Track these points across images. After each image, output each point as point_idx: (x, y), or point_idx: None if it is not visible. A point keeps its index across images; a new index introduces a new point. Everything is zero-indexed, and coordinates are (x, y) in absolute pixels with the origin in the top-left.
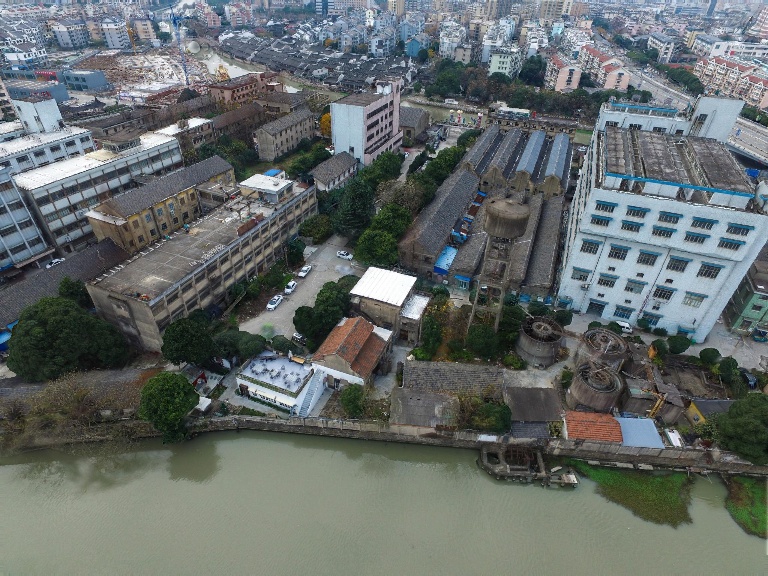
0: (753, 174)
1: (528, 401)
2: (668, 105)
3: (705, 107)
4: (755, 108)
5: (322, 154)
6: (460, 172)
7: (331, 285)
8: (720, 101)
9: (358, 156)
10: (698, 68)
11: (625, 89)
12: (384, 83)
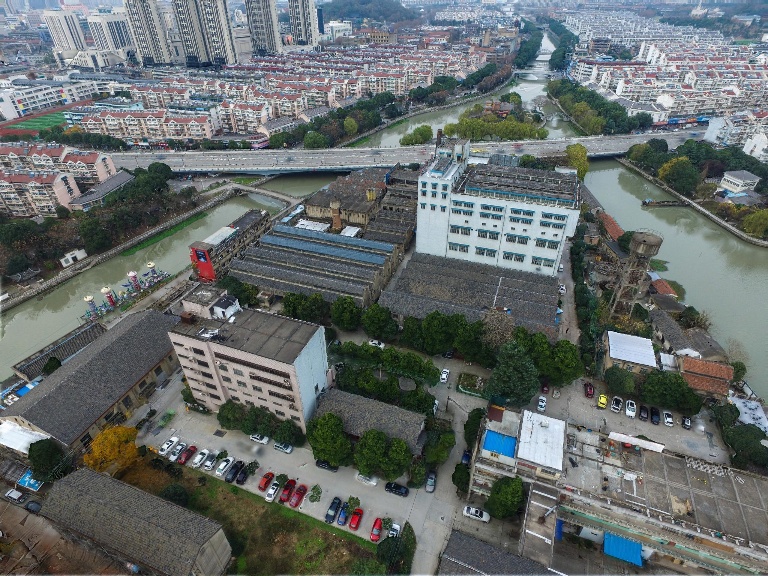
0: (388, 176)
1: (668, 304)
2: (440, 158)
3: (465, 150)
4: (208, 140)
5: (341, 421)
6: (388, 296)
7: (661, 377)
8: (467, 144)
9: (322, 387)
10: (92, 126)
11: (121, 171)
12: (228, 300)
